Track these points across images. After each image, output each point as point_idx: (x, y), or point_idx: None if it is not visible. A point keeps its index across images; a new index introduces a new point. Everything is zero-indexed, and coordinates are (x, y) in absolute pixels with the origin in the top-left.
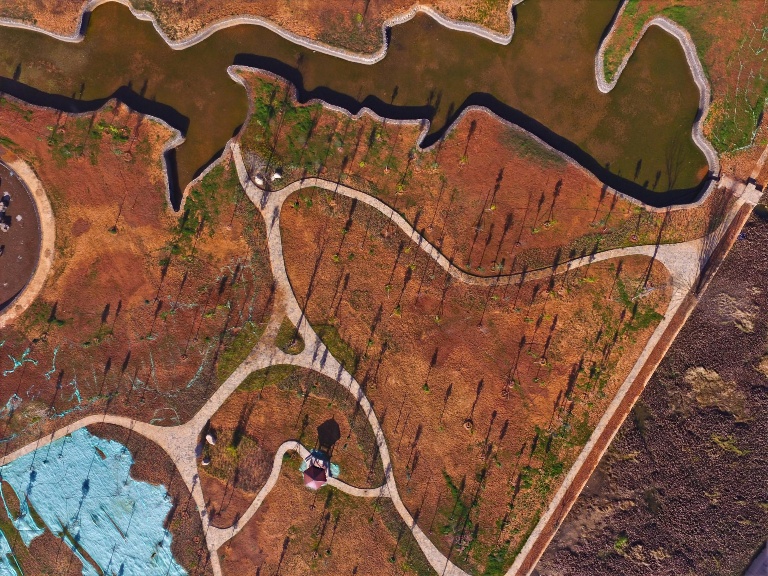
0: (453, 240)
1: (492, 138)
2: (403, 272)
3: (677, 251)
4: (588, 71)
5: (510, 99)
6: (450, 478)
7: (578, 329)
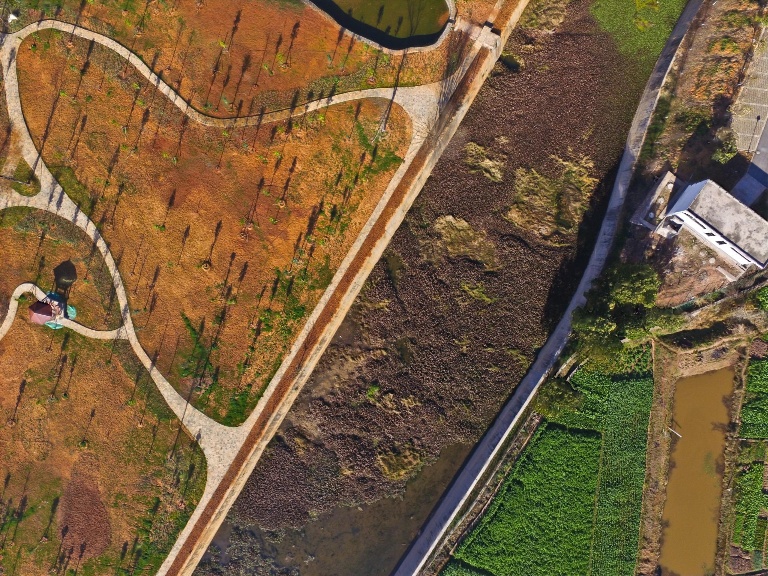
0: (191, 82)
1: None
2: (141, 114)
3: (415, 94)
4: None
5: None
6: (189, 320)
7: (318, 172)
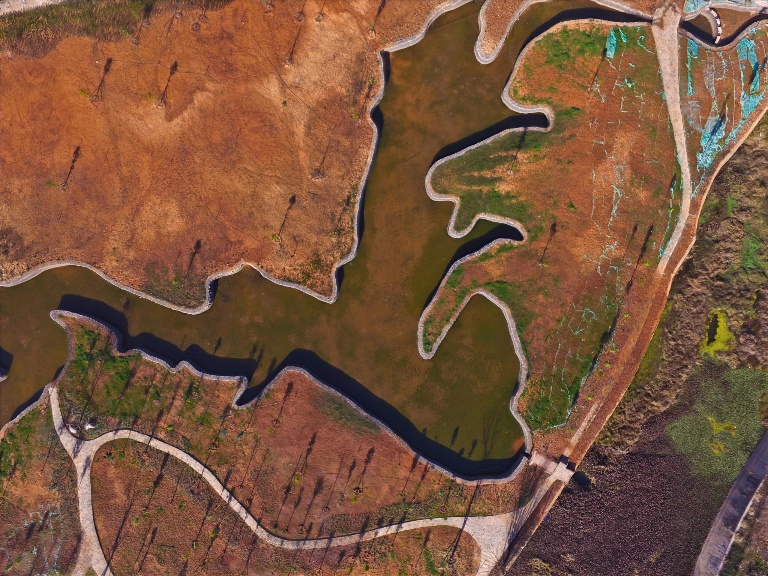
0: (262, 500)
1: (308, 401)
2: (211, 529)
3: (486, 524)
4: (411, 335)
5: (332, 358)
6: None
7: None
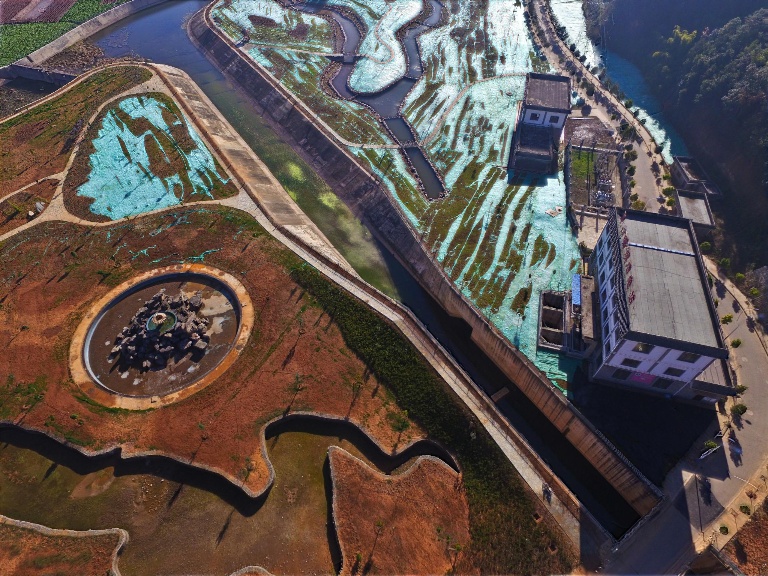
0: None
1: None
2: None
3: None
4: None
5: None
6: None
7: None
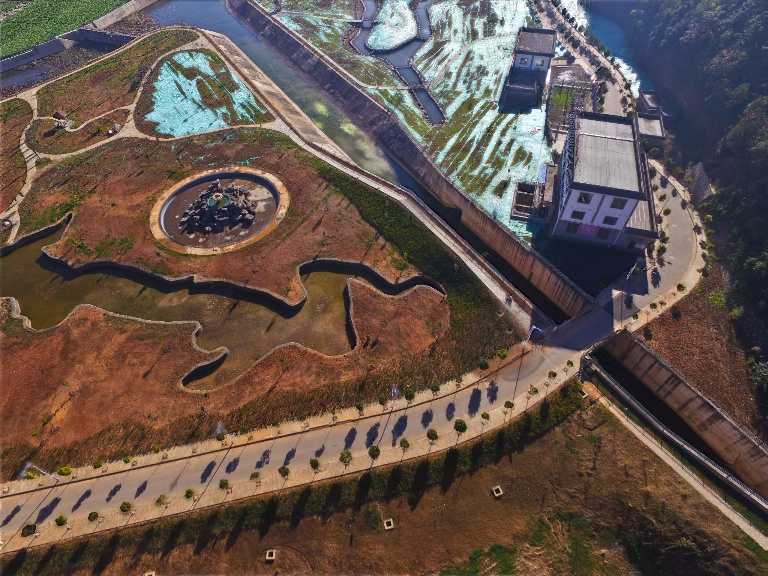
0: None
1: None
2: None
3: None
4: None
5: None
6: (4, 122)
7: None
